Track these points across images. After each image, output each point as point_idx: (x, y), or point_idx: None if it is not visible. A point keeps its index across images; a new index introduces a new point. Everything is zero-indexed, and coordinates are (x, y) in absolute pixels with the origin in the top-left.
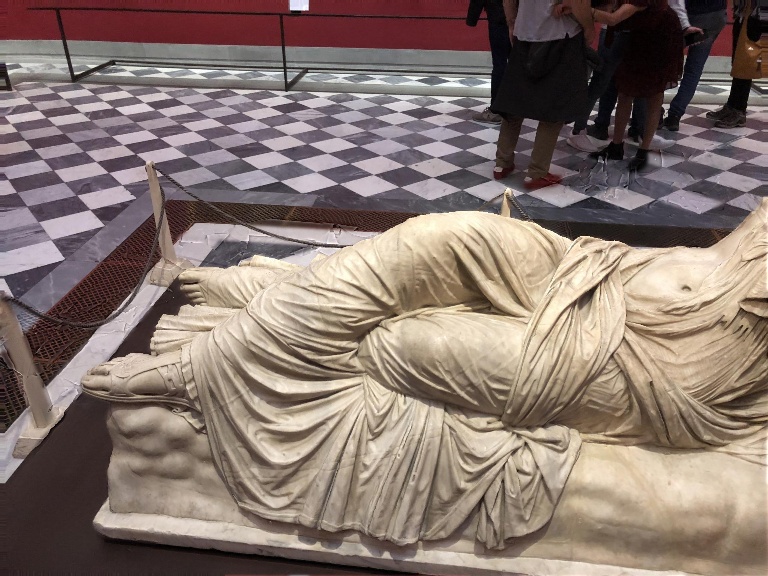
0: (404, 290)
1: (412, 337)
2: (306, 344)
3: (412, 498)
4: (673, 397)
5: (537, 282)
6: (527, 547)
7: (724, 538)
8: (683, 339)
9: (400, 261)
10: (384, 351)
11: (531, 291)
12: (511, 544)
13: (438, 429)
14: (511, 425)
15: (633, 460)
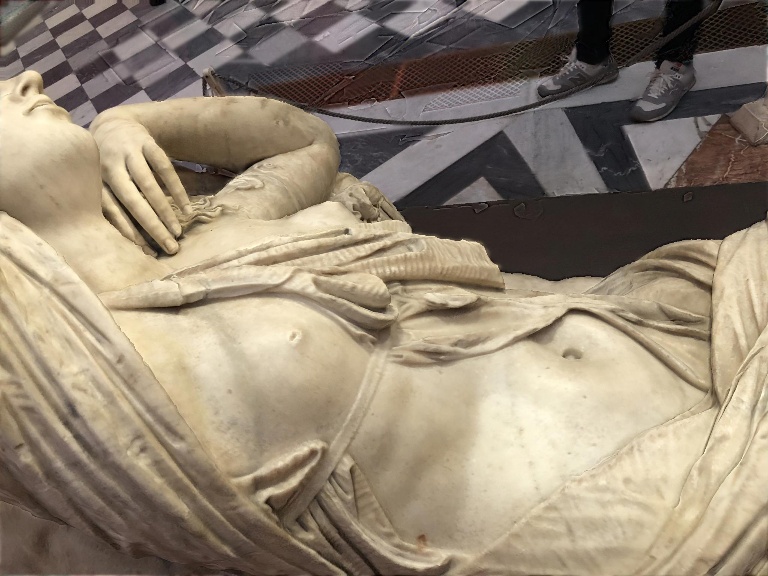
0: None
1: None
2: None
3: None
4: None
5: None
6: None
7: None
8: None
9: None
10: None
11: None
12: None
13: None
14: None
15: None
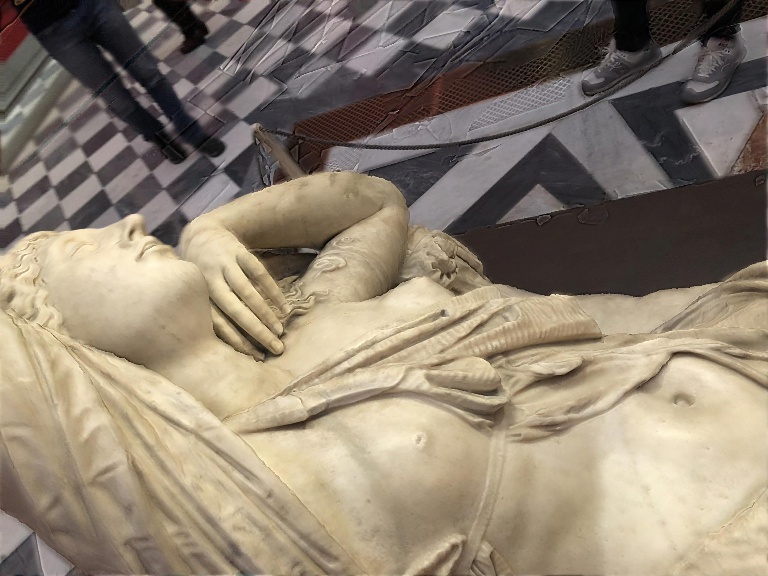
0: None
1: None
2: None
3: None
4: None
5: None
6: None
7: None
8: None
9: None
10: None
11: None
12: None
13: None
14: None
15: None
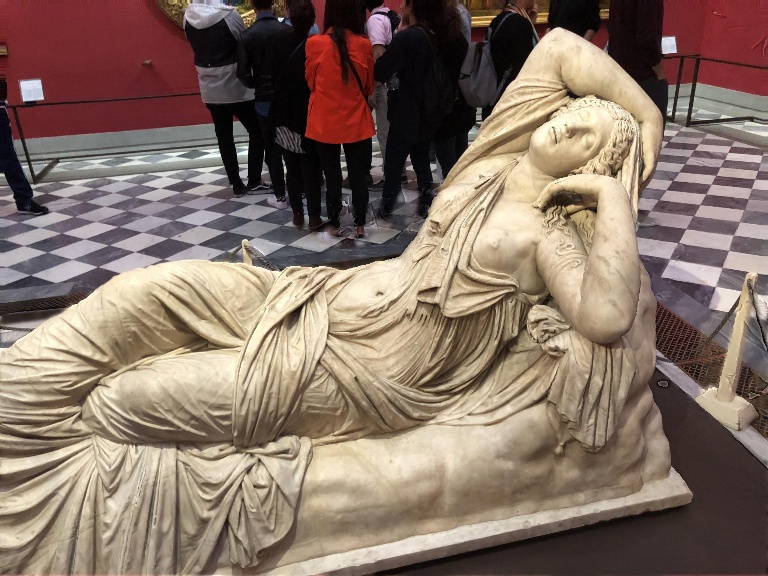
0: (117, 345)
1: (129, 387)
2: (20, 419)
3: (157, 541)
4: (378, 386)
5: (250, 314)
6: (281, 556)
7: (441, 495)
8: (381, 336)
9: (106, 318)
10: (106, 407)
11: (245, 323)
12: (264, 557)
13: (172, 468)
14: (244, 447)
15: (360, 450)
